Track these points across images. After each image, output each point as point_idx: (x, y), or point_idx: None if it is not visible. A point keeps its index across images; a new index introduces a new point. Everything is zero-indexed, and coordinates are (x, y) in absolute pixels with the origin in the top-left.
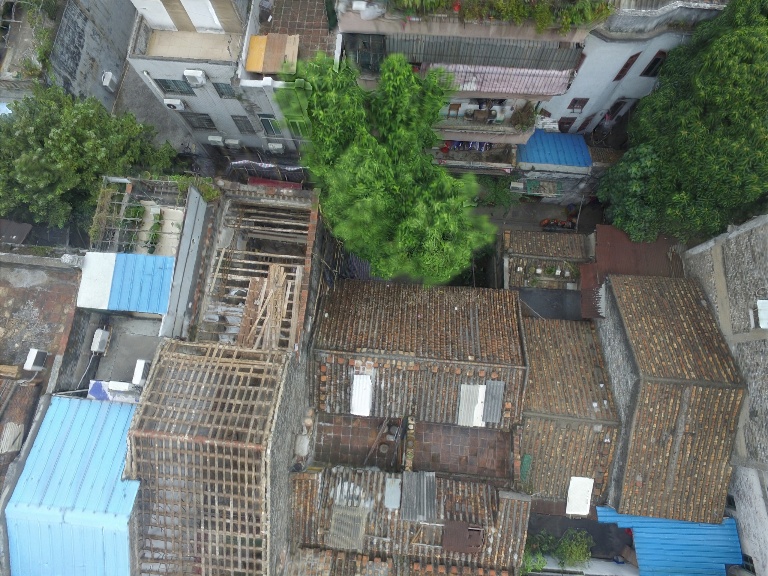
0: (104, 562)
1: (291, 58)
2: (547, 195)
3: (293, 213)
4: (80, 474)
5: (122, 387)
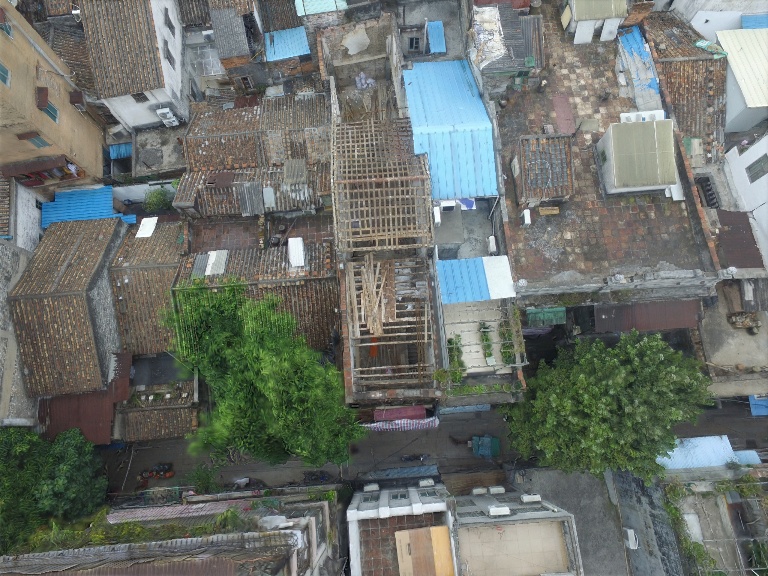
0: (425, 114)
1: (403, 552)
2: (160, 489)
3: (388, 405)
4: (455, 152)
5: (445, 203)
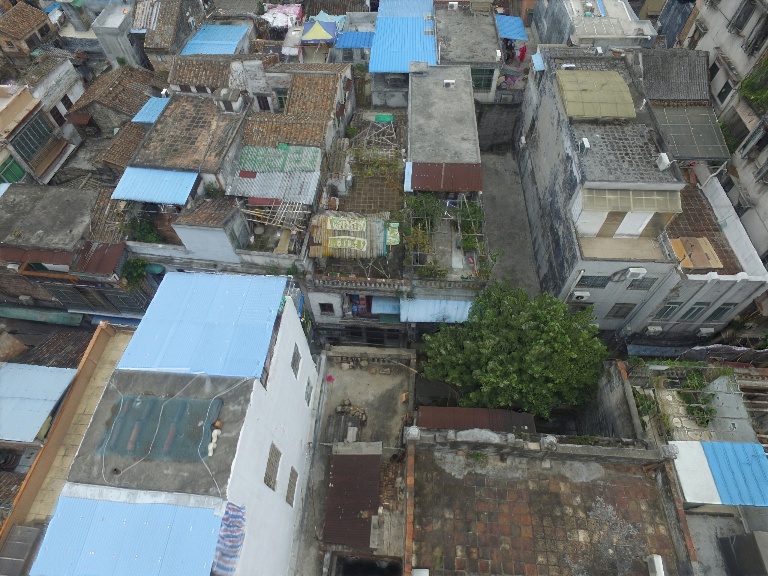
0: None
1: (712, 256)
2: None
3: None
4: None
5: None
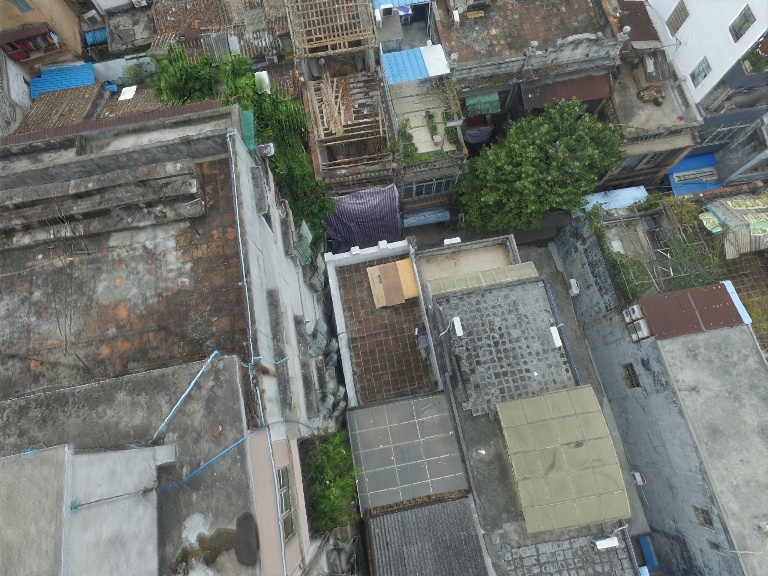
0: None
1: (375, 281)
2: None
3: None
4: None
5: (384, 6)
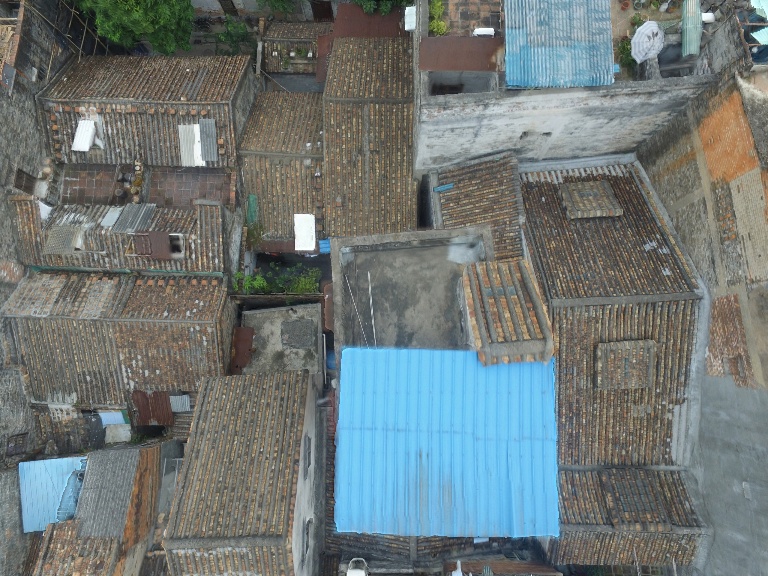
0: None
1: None
2: None
3: None
4: None
5: None
